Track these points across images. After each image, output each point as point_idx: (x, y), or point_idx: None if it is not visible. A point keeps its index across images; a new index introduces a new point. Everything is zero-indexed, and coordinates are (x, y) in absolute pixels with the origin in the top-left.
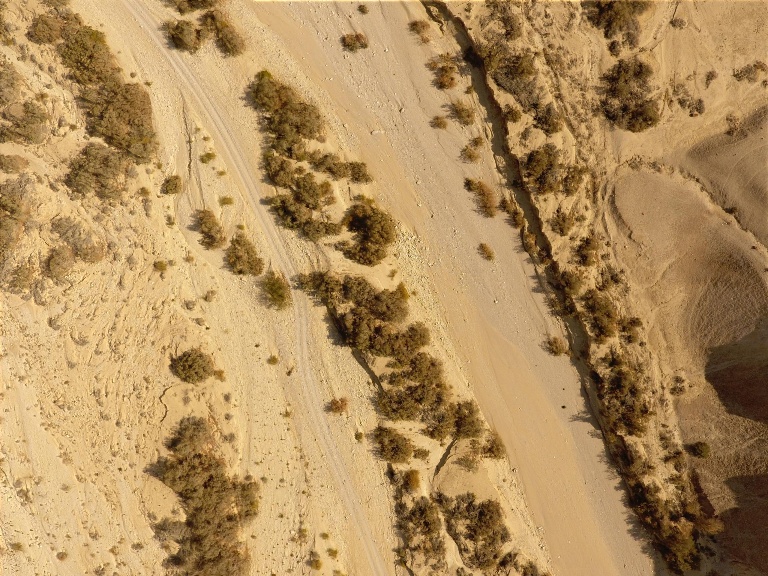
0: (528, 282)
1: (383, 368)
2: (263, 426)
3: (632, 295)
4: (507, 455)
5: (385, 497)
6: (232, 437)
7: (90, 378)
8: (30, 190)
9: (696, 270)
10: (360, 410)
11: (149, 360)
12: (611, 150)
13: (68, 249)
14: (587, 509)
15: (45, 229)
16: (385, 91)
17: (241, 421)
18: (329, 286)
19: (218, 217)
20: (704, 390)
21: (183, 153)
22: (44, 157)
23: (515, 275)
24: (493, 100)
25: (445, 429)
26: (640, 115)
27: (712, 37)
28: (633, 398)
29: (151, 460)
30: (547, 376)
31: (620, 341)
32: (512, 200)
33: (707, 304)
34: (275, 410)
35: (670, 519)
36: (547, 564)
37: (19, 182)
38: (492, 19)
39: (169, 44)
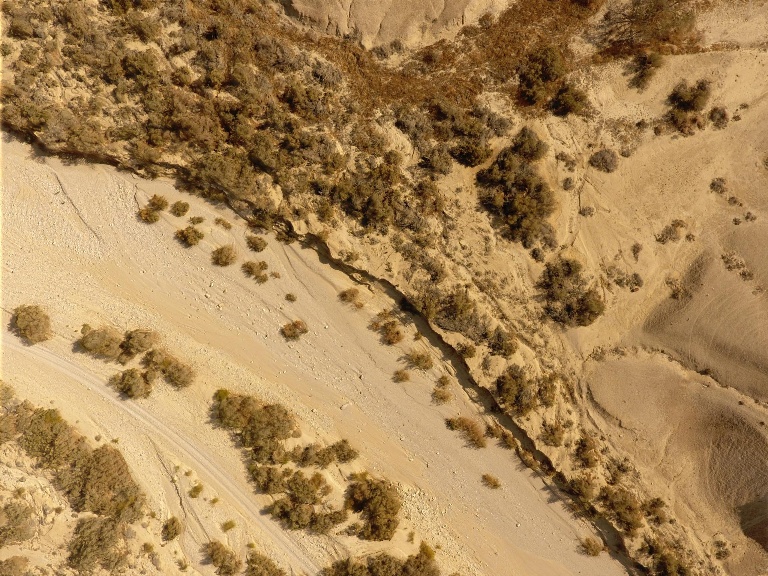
0: (541, 495)
1: None
2: None
3: (644, 478)
4: None
5: None
6: None
7: None
8: None
9: (695, 437)
10: None
11: None
12: (571, 350)
13: None
14: None
15: None
16: (339, 365)
17: None
18: None
19: (226, 544)
20: (748, 546)
21: (171, 494)
22: (41, 549)
23: (526, 493)
24: (443, 341)
25: None
26: (585, 311)
27: (623, 213)
28: None
29: None
30: None
31: (650, 526)
32: (496, 424)
33: (718, 467)
34: None
35: None
36: None
37: None
38: (414, 270)
39: (121, 396)
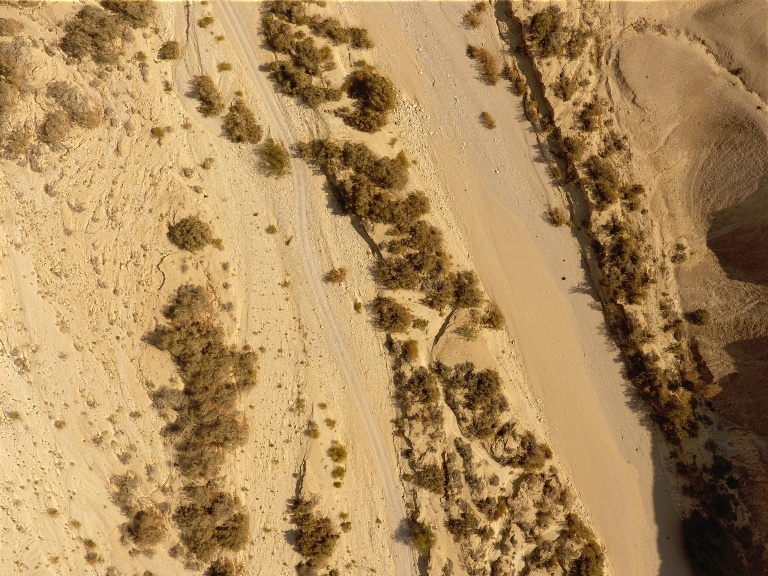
0: (530, 152)
1: (383, 236)
2: (261, 296)
3: (635, 162)
4: (506, 327)
5: (384, 368)
6: (230, 306)
7: (87, 245)
8: (25, 53)
9: (700, 134)
10: (359, 280)
11: (147, 228)
12: (616, 13)
13: (64, 114)
14: (586, 381)
15: (41, 93)
16: None
17: (239, 291)
18: (329, 151)
19: (216, 83)
20: (705, 257)
21: (181, 18)
22: (39, 20)
23: (517, 144)
24: None
25: (444, 298)
26: None
27: None
28: (634, 266)
29: (149, 328)
30: (548, 247)
31: (622, 209)
32: (515, 67)
33: (710, 168)
34: (274, 280)
35: (669, 388)
36: (545, 436)
37: (14, 44)
38: None
39: None
